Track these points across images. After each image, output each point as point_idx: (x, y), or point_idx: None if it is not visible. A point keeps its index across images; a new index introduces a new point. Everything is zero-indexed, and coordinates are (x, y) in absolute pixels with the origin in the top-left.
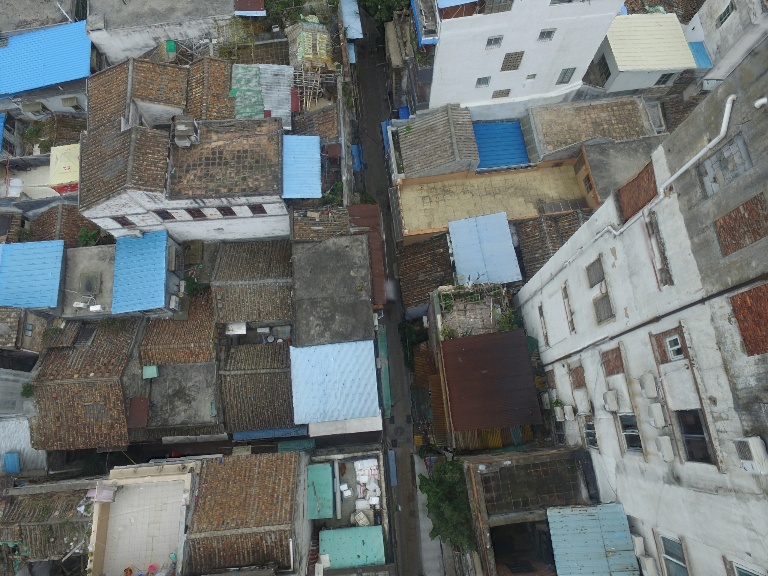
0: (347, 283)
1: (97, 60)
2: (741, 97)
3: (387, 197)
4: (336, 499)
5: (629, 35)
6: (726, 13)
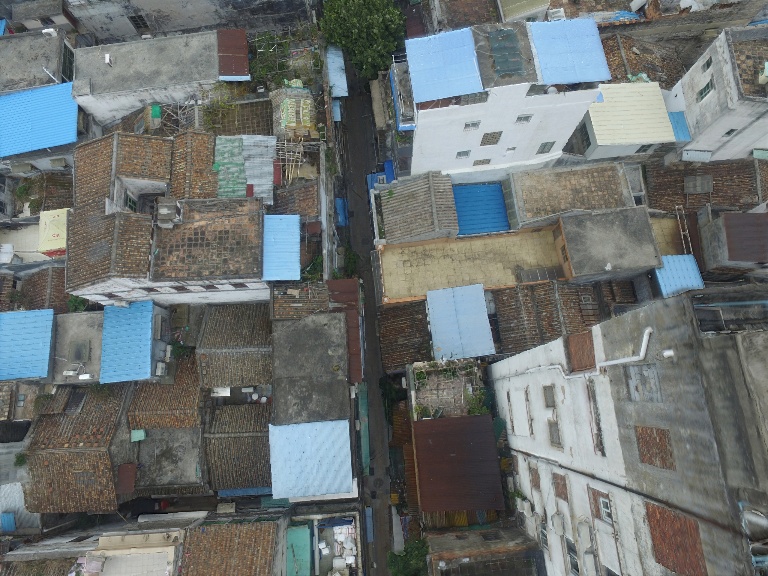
0: (324, 362)
1: (84, 122)
2: (656, 334)
3: (372, 246)
4: (315, 556)
5: (610, 106)
6: (706, 89)
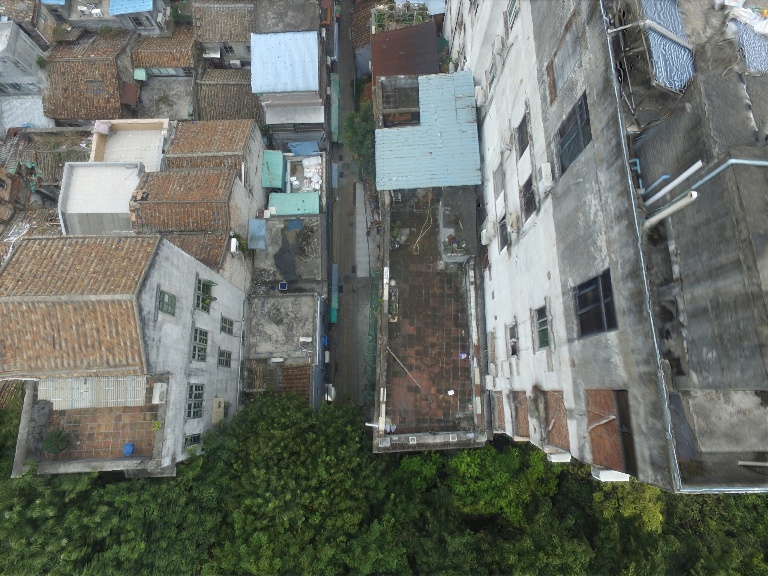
0: None
1: None
2: None
3: None
4: (287, 188)
5: None
6: None
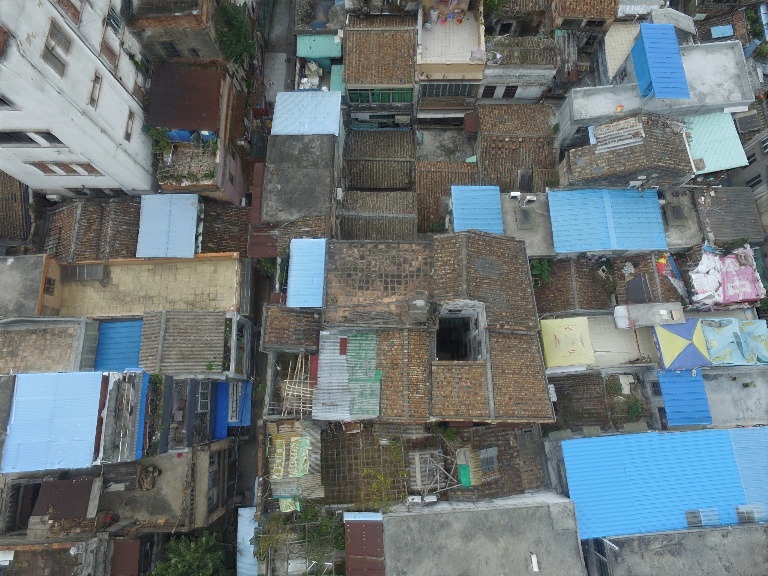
0: (285, 179)
1: None
2: None
3: None
4: None
5: None
6: None
